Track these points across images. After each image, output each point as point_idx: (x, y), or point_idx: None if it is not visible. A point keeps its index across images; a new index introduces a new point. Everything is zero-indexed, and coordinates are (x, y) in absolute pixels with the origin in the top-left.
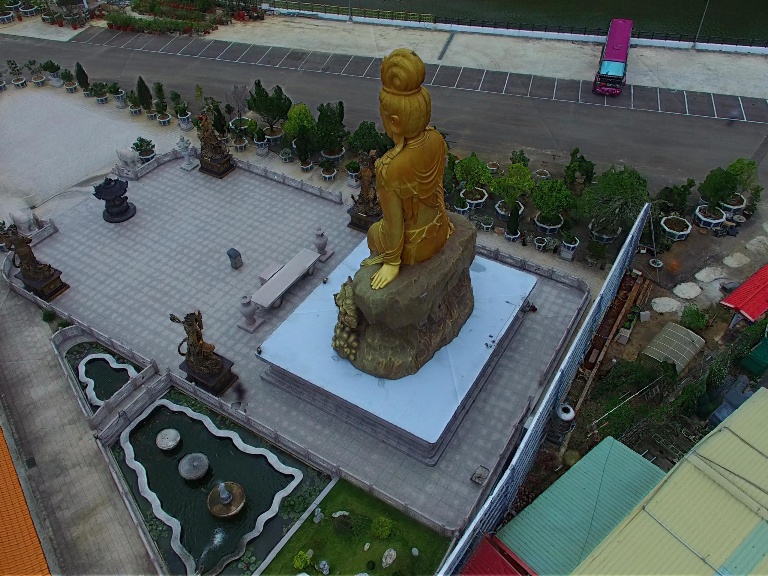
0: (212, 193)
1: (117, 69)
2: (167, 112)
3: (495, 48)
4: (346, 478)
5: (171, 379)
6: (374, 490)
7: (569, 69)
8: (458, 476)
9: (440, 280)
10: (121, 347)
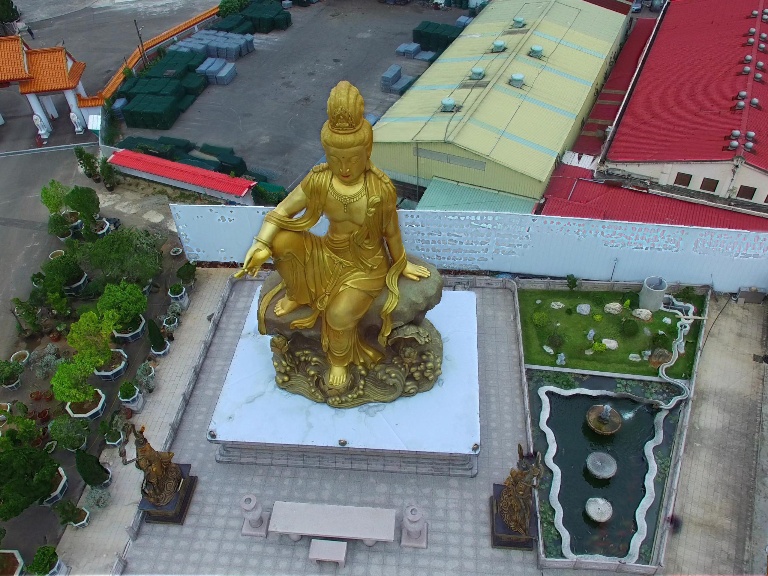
0: None
1: None
2: None
3: None
4: None
5: None
6: None
7: None
8: None
9: None
10: None
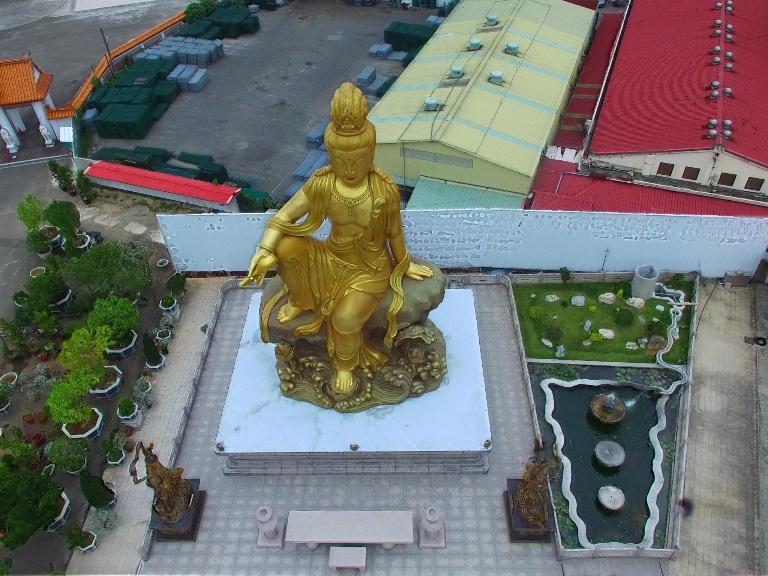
0: None
1: None
2: None
3: None
4: None
5: None
6: None
7: None
8: None
9: None
10: None
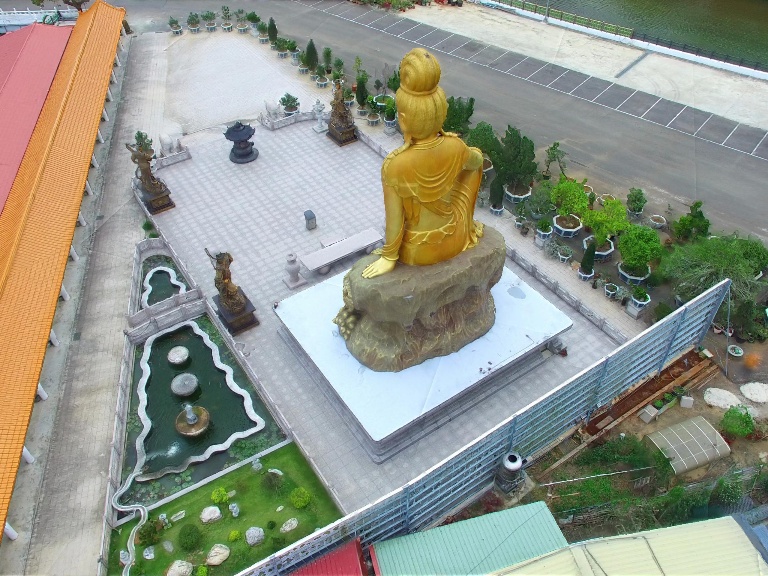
0: (326, 157)
1: (309, 30)
2: (328, 76)
3: (686, 77)
4: (297, 443)
5: (207, 306)
6: (311, 462)
7: (761, 116)
8: (396, 482)
9: (432, 288)
10: (183, 267)
